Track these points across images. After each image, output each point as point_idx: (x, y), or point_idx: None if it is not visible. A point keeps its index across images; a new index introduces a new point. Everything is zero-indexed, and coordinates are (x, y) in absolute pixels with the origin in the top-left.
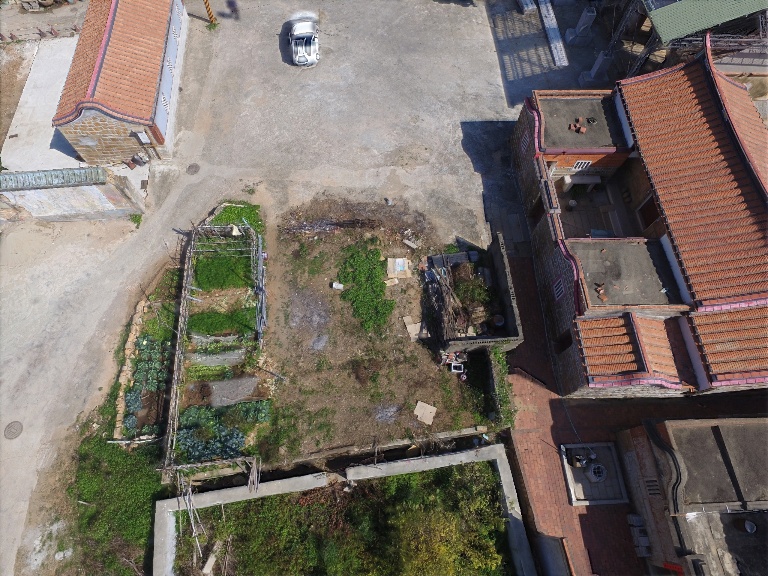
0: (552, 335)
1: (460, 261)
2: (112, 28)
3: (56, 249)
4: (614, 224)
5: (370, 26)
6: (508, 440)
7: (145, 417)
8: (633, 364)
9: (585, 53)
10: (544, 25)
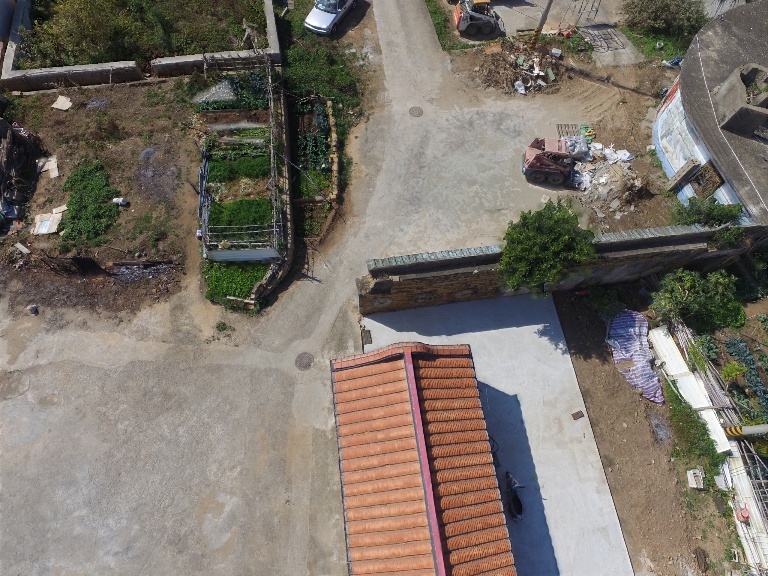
0: None
1: None
2: None
3: None
4: None
5: None
6: None
7: None
8: None
9: None
10: None
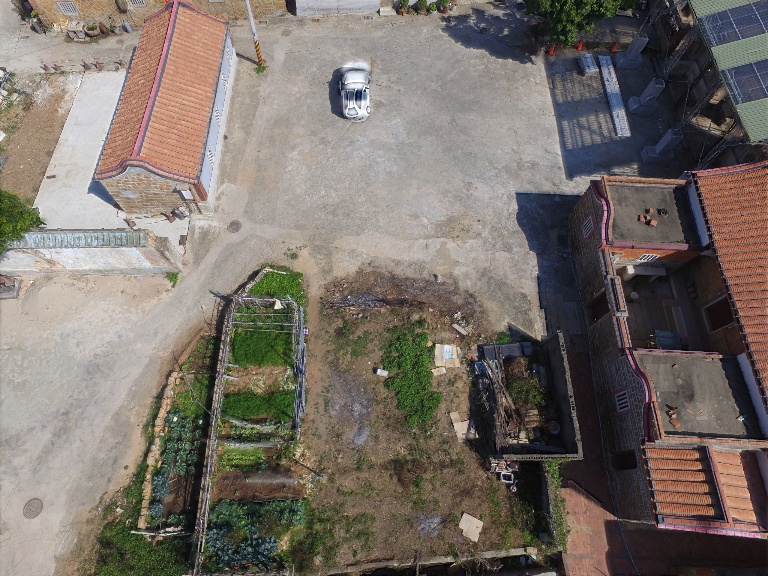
0: (609, 446)
1: (513, 354)
2: (162, 76)
3: (88, 305)
4: (678, 321)
5: (424, 79)
6: (558, 563)
7: (171, 504)
8: (709, 508)
9: (648, 123)
10: (606, 90)
